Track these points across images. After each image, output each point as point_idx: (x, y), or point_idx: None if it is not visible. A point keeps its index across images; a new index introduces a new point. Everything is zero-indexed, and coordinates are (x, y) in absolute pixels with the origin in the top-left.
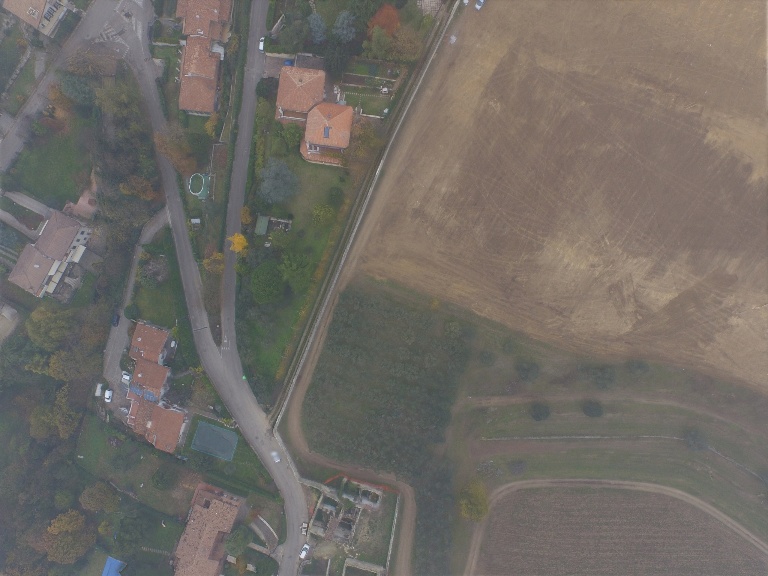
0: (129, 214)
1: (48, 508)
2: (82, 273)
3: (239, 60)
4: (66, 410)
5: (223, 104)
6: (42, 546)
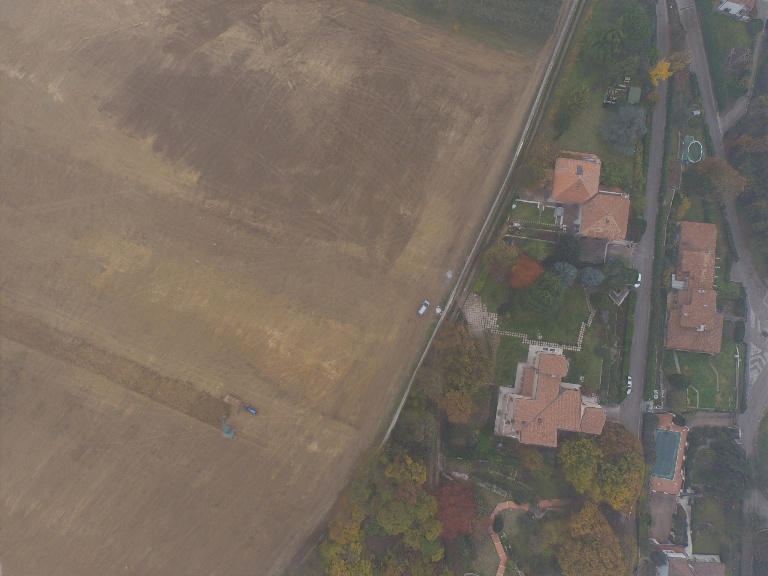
0: None
1: None
2: None
3: (661, 262)
4: None
5: (673, 226)
6: None
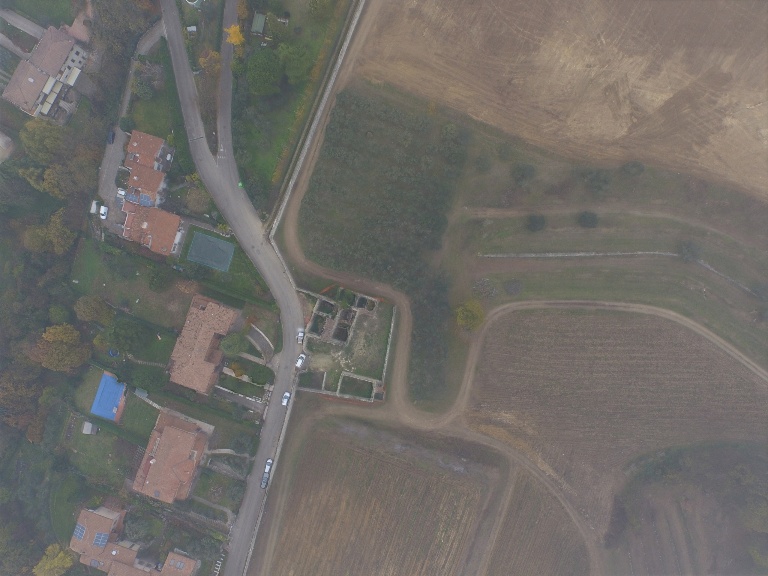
0: (125, 11)
1: (43, 321)
2: (77, 98)
3: None
4: (61, 226)
5: None
6: (37, 354)
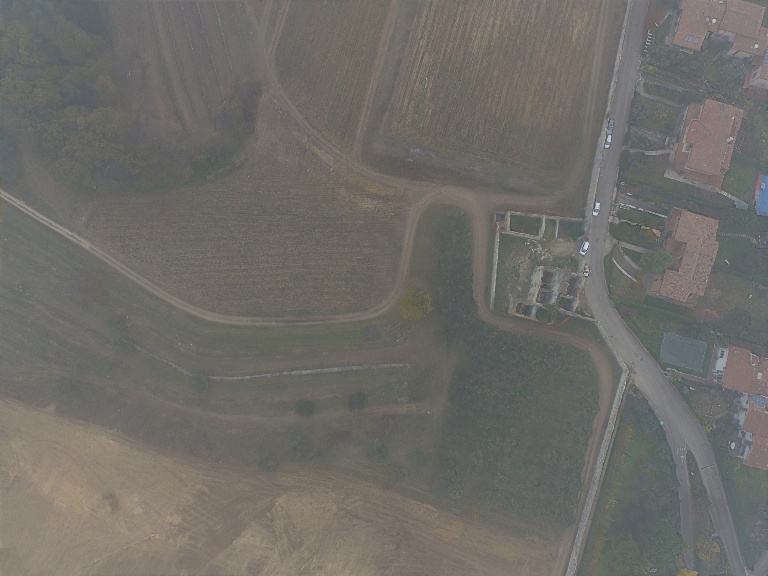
0: None
1: None
2: None
3: None
4: None
5: None
6: None
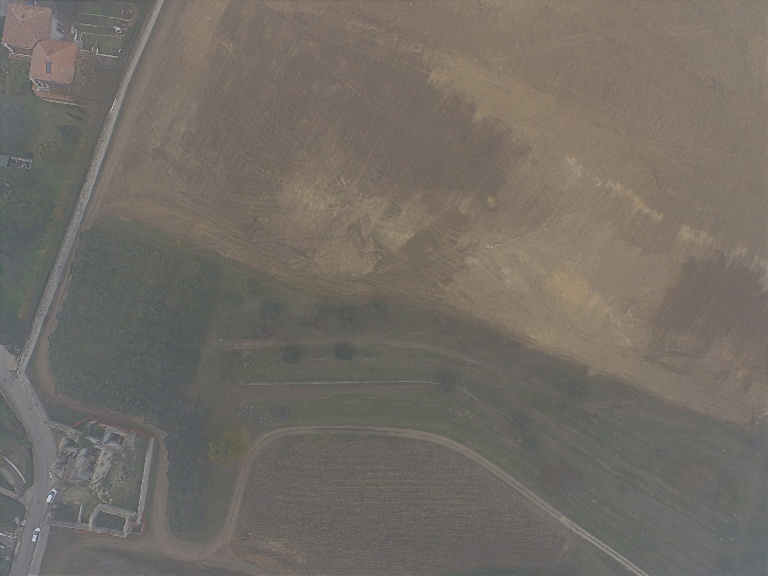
0: None
1: None
2: None
3: None
4: None
5: None
6: None
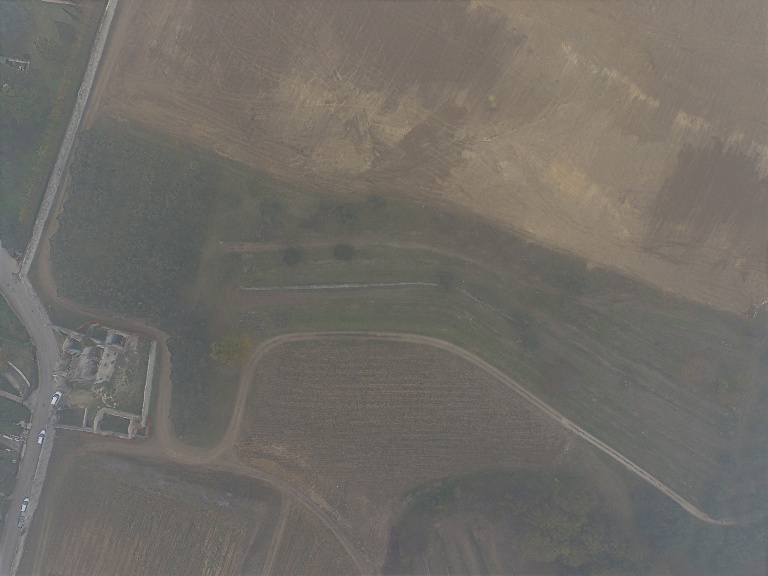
0: None
1: None
2: None
3: None
4: None
5: None
6: None
